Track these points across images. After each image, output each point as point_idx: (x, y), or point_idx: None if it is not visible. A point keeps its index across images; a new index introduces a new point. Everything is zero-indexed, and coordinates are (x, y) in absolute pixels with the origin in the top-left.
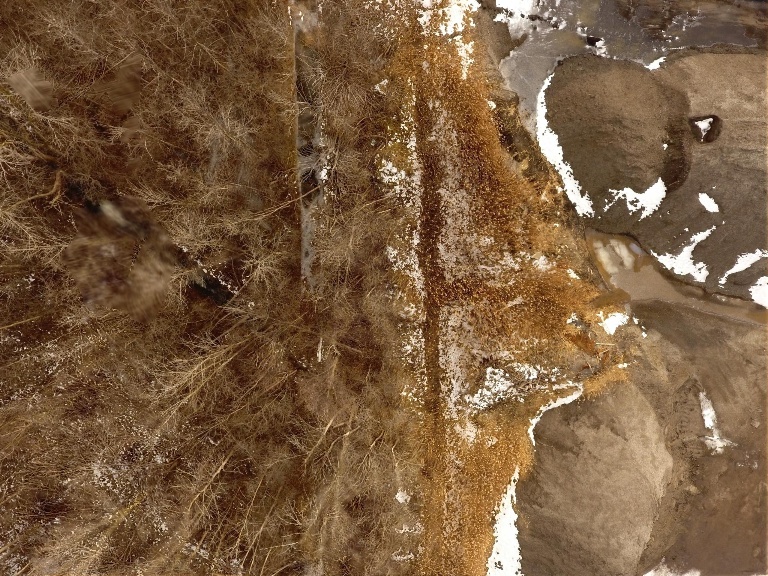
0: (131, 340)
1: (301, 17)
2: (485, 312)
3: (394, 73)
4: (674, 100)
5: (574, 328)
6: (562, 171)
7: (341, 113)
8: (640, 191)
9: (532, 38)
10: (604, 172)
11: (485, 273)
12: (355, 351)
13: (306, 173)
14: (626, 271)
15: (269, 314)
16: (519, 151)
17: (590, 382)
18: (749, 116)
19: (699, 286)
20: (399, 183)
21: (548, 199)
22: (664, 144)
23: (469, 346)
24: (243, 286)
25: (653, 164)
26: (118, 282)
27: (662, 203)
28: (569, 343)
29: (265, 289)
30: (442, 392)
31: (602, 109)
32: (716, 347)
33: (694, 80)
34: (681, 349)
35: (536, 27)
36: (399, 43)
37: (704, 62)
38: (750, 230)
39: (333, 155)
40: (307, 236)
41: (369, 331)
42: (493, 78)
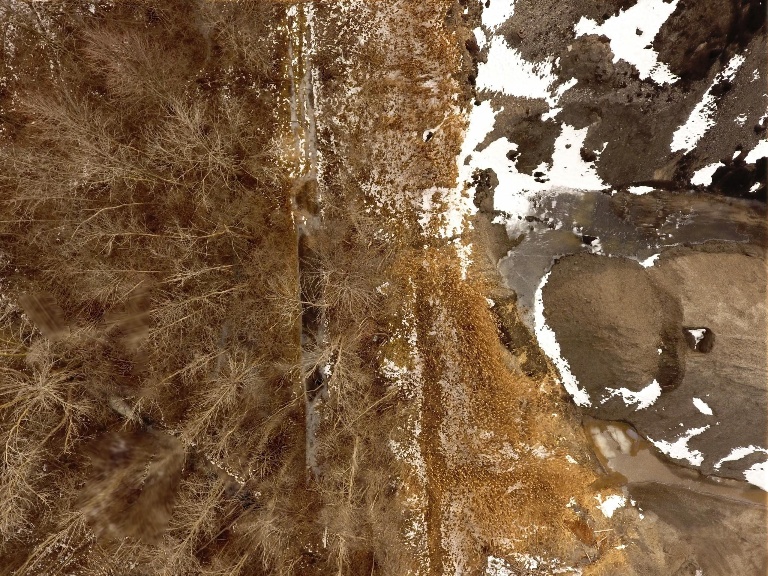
0: (143, 575)
1: (304, 221)
2: (486, 498)
3: (395, 275)
4: (668, 306)
5: (573, 514)
6: (560, 365)
7: (344, 315)
8: (636, 390)
9: (529, 238)
10: (600, 373)
11: (485, 461)
12: (359, 539)
13: (310, 368)
14: (623, 455)
15: (275, 504)
16: (517, 347)
17: (589, 568)
18: (741, 334)
19: (694, 469)
20: (401, 378)
21: (546, 390)
22: (659, 349)
23: (470, 530)
24: (250, 478)
25: (648, 368)
26: (130, 506)
27: (657, 400)
28: (568, 531)
29: (271, 480)
30: (445, 572)
31: (598, 315)
32: (712, 527)
33: (687, 286)
34: (677, 529)
35: (533, 228)
36: (400, 245)
37: (697, 265)
38: (743, 431)
39: (336, 351)
40: (312, 428)
41: (373, 525)
42: (491, 277)
